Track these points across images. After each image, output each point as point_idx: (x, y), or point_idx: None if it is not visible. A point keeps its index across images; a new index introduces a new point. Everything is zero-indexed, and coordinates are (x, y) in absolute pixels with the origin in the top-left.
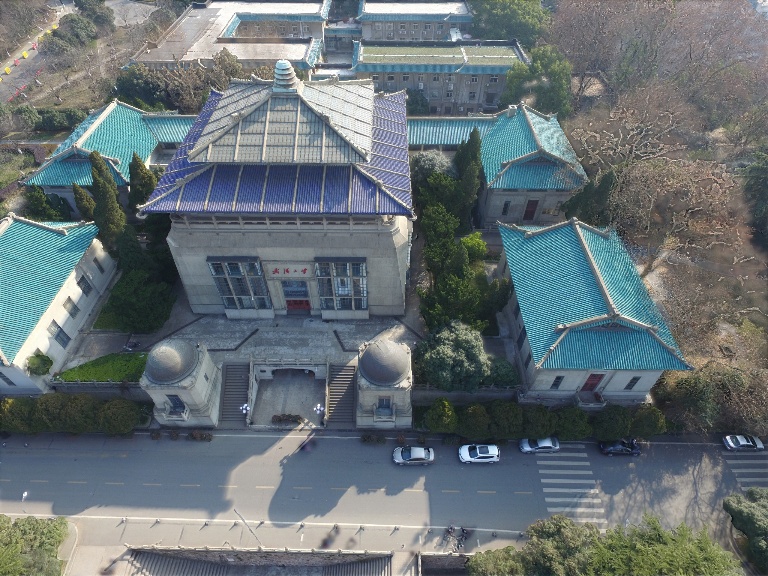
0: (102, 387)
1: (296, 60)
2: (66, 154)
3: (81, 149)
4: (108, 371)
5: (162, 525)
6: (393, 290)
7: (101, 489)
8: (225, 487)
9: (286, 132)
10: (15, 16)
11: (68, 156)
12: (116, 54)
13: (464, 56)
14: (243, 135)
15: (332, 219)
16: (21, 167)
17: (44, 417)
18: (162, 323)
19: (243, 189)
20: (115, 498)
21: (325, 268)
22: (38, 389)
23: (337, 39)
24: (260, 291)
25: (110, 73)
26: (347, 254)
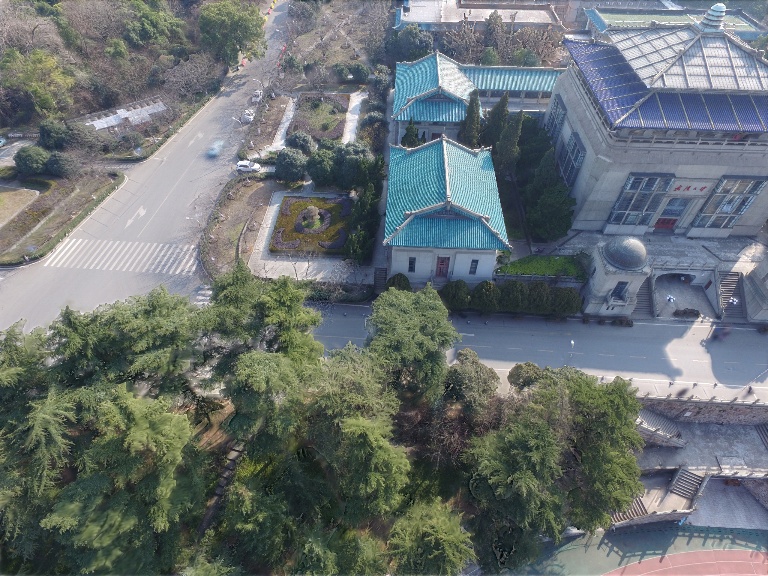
0: (535, 280)
1: (552, 23)
2: (429, 94)
3: (445, 90)
4: (539, 267)
5: (636, 383)
6: (765, 210)
7: (568, 356)
8: (668, 359)
9: (724, 65)
10: None
11: (431, 96)
12: (346, 19)
13: None
14: (688, 67)
15: (752, 141)
16: (331, 112)
17: (520, 296)
18: (566, 232)
19: (689, 112)
20: (584, 363)
21: (729, 185)
22: (490, 278)
23: None
24: (653, 207)
25: None
26: (753, 173)
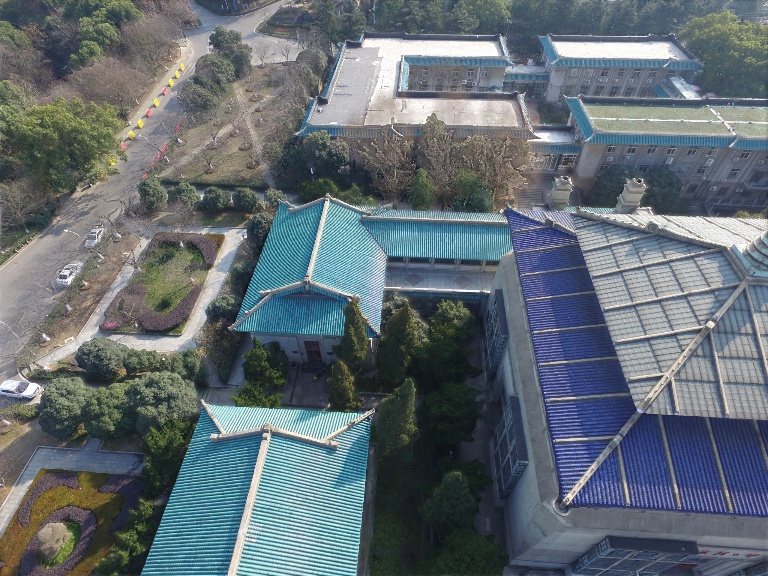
0: None
1: (516, 127)
2: (291, 289)
3: (314, 284)
4: None
5: None
6: None
7: None
8: None
9: None
10: (145, 57)
11: (294, 292)
12: None
13: (724, 122)
14: (722, 360)
15: None
16: (187, 269)
17: None
18: None
19: (727, 459)
20: None
21: None
22: None
23: (514, 85)
24: (655, 568)
25: (276, 137)
26: None
